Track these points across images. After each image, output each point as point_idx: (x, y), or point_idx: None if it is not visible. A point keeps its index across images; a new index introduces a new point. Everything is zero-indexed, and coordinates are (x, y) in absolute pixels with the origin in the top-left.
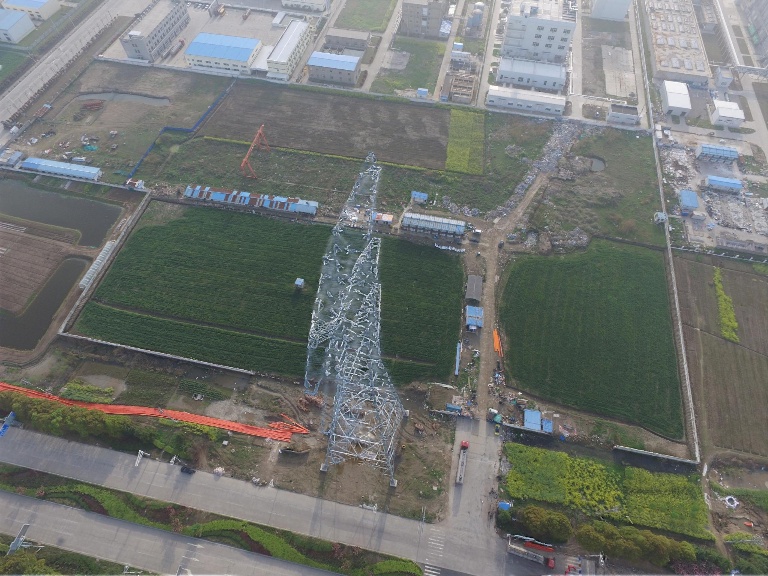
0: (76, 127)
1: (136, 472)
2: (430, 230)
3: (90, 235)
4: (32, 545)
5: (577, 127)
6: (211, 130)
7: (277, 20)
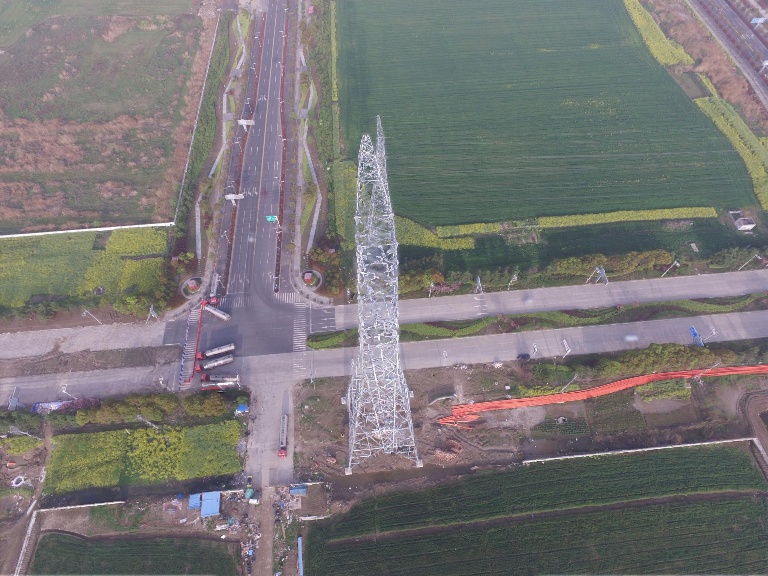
0: None
1: None
2: None
3: None
4: None
5: None
6: None
7: None
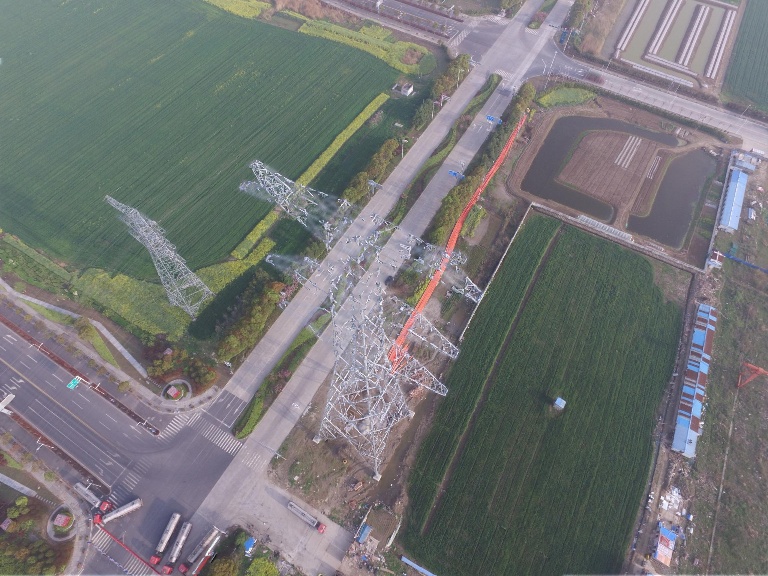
0: None
1: None
2: None
3: (642, 223)
4: None
5: None
6: None
7: None
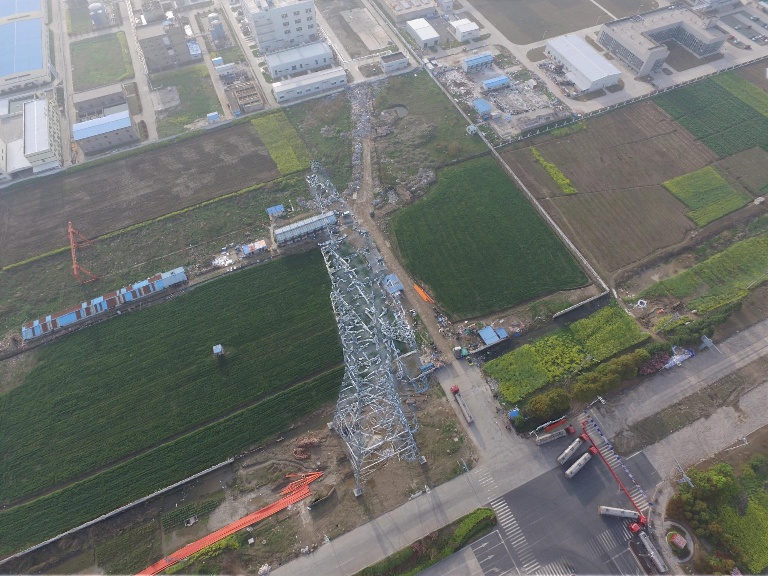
0: None
1: None
2: (306, 234)
3: None
4: None
5: (366, 88)
6: (6, 258)
7: (3, 111)
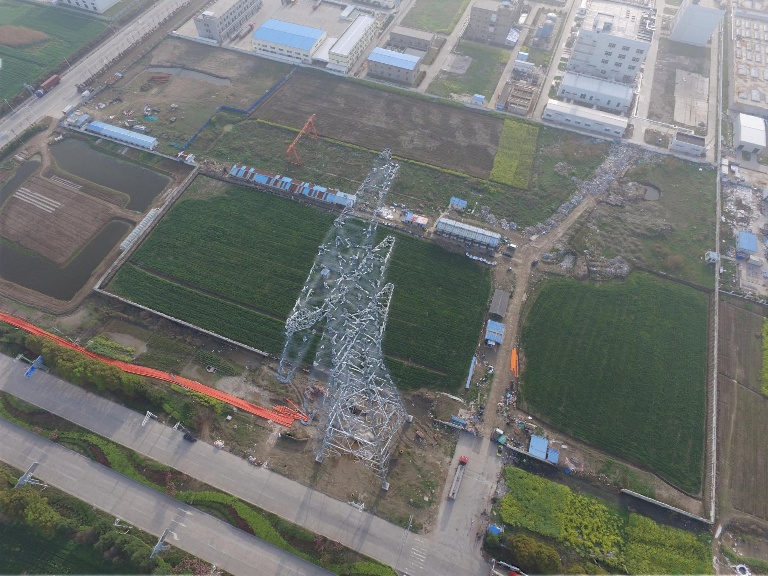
0: (141, 97)
1: (142, 431)
2: (463, 238)
3: (137, 200)
4: (38, 483)
5: (636, 152)
6: (265, 114)
7: (345, 13)
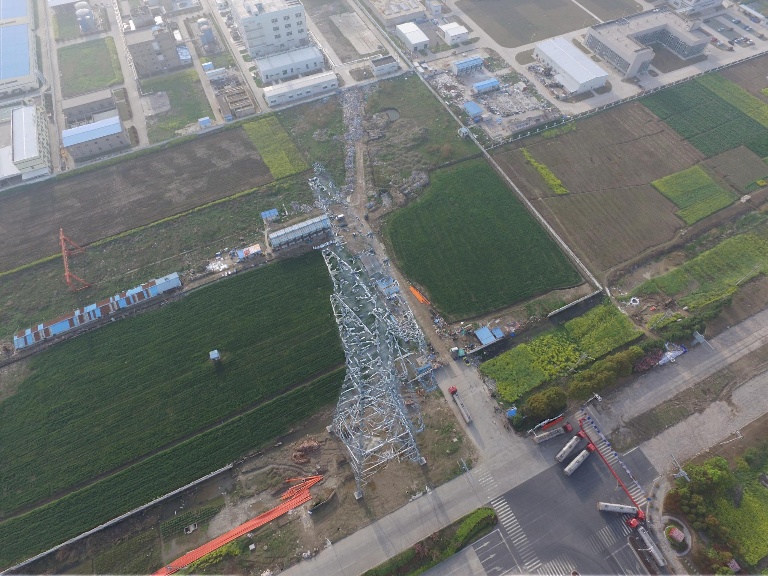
0: None
1: None
2: (301, 238)
3: None
4: None
5: (357, 92)
6: None
7: None
